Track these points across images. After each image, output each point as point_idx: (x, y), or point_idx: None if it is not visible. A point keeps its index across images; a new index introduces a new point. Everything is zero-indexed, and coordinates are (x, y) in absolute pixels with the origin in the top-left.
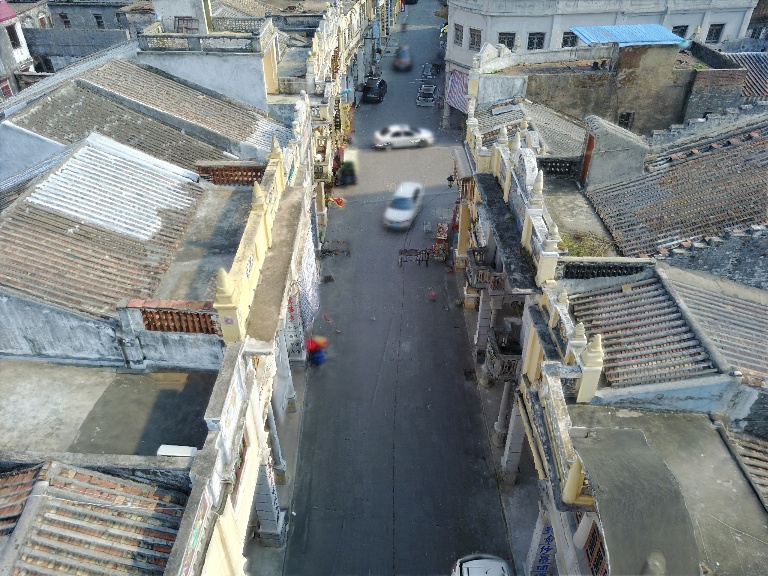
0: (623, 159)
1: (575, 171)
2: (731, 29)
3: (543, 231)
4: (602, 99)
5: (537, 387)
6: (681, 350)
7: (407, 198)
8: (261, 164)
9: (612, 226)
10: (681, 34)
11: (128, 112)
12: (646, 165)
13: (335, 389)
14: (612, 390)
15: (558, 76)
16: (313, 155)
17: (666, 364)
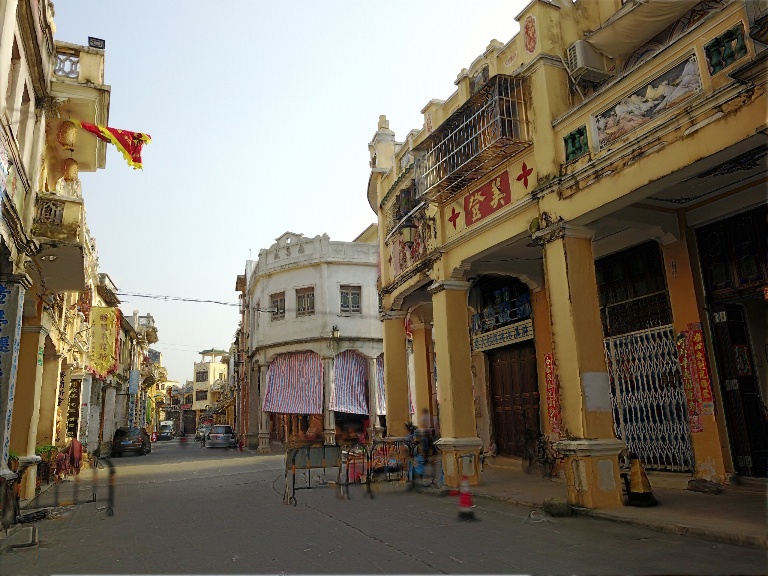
0: None
1: None
2: None
3: None
4: None
5: None
6: None
7: (240, 472)
8: None
9: None
10: None
11: None
12: None
13: None
14: None
15: None
16: (40, 162)
17: None
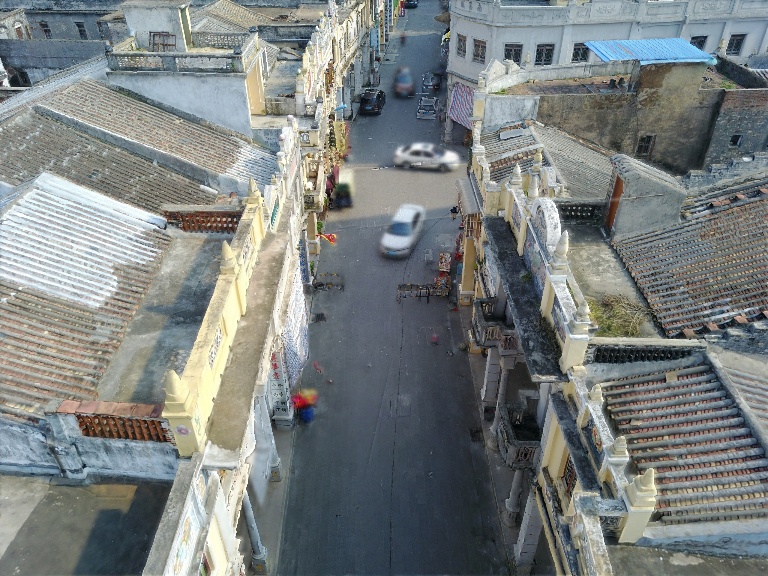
0: (657, 206)
1: (599, 216)
2: (753, 39)
3: (569, 305)
4: (620, 121)
5: (567, 518)
6: (748, 472)
7: (406, 223)
8: (237, 209)
9: (647, 289)
10: (700, 45)
11: (93, 142)
12: (682, 211)
13: (325, 452)
14: (664, 528)
15: (572, 97)
16: (303, 184)
17: (730, 492)
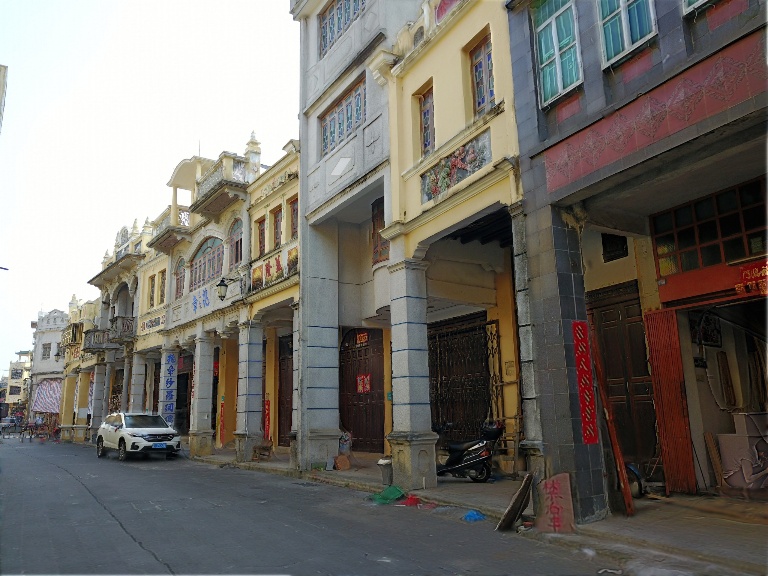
0: None
1: None
2: None
3: None
4: None
5: None
6: None
7: None
8: None
9: None
10: None
11: None
12: None
13: None
14: None
15: None
16: None
17: None
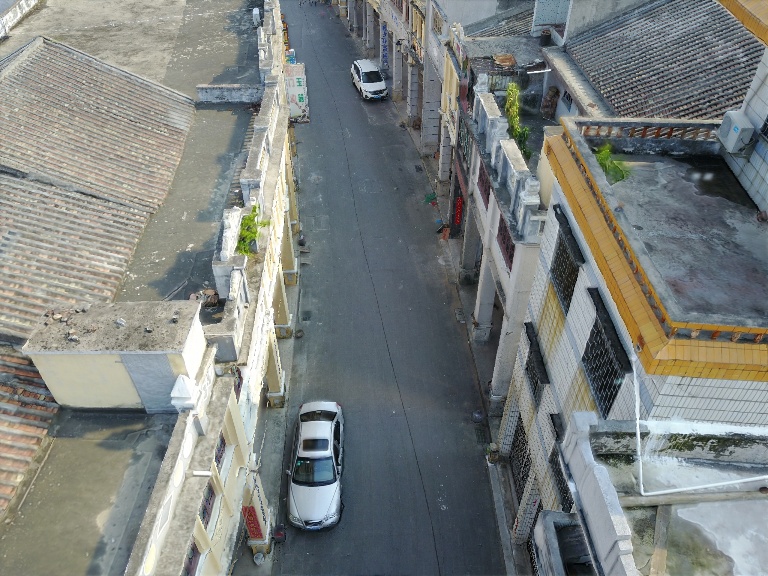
0: None
1: None
2: None
3: None
4: None
5: None
6: None
7: None
8: None
9: None
10: None
11: None
12: None
13: None
14: None
15: None
16: None
17: None
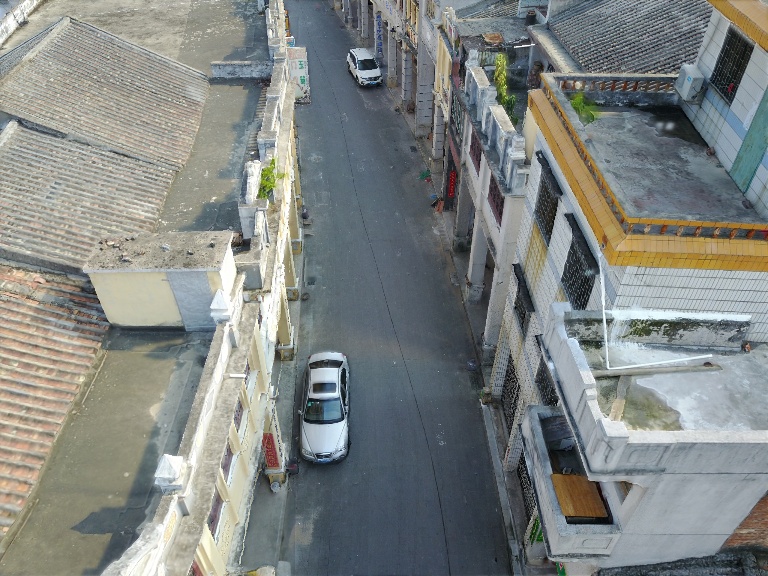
0: None
1: None
2: None
3: None
4: None
5: None
6: None
7: None
8: None
9: None
10: None
11: None
12: None
13: None
14: None
15: None
16: None
17: None
